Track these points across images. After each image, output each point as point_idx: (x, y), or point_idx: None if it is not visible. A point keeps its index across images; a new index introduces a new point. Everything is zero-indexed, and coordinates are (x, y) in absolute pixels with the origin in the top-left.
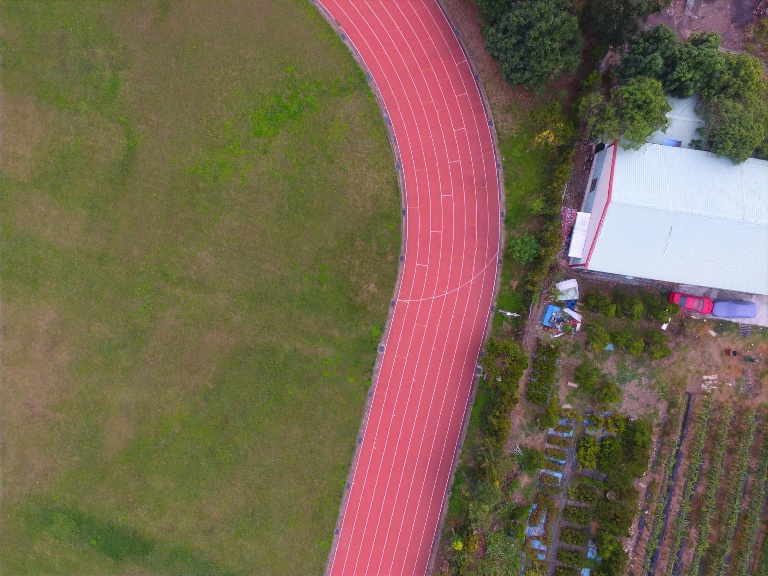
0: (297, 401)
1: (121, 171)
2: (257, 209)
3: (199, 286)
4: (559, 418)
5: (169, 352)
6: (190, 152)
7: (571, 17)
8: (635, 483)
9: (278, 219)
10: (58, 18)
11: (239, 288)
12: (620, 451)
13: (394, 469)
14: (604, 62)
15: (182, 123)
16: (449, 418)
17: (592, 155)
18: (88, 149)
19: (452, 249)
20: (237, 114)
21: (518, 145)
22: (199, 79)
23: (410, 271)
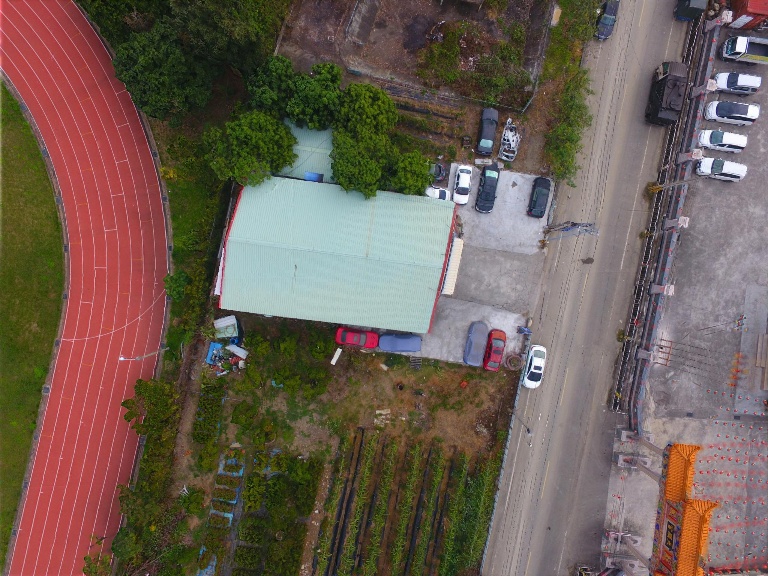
0: None
1: None
2: None
3: None
4: (226, 458)
5: None
6: None
7: None
8: (308, 521)
9: None
10: None
11: None
12: (286, 490)
13: (62, 513)
14: None
15: None
16: (120, 459)
17: None
18: None
19: (118, 285)
20: None
21: None
22: None
23: (74, 309)
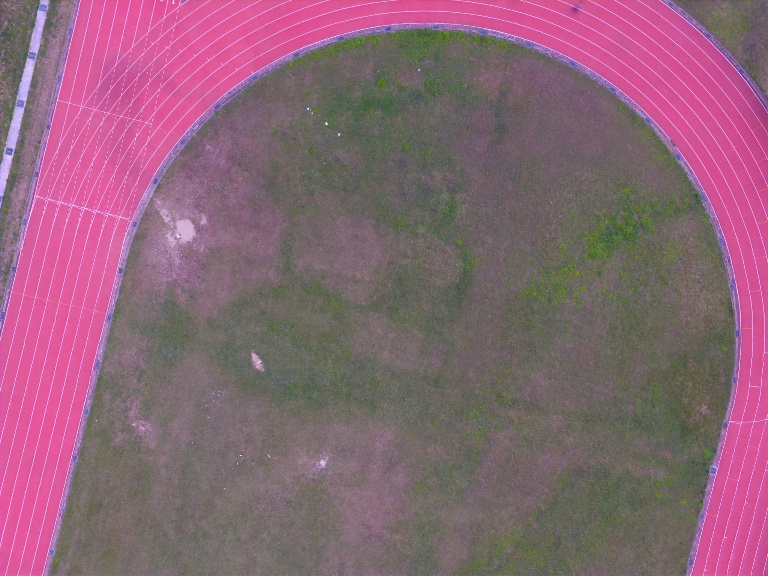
0: (629, 523)
1: (457, 294)
2: (591, 331)
3: (533, 408)
4: None
5: (503, 474)
6: (525, 274)
7: None
8: None
9: (612, 341)
10: (397, 142)
11: (572, 410)
12: None
13: None
14: None
15: (518, 245)
16: None
17: None
18: (425, 272)
19: None
20: (572, 236)
21: None
22: (535, 202)
23: (743, 393)
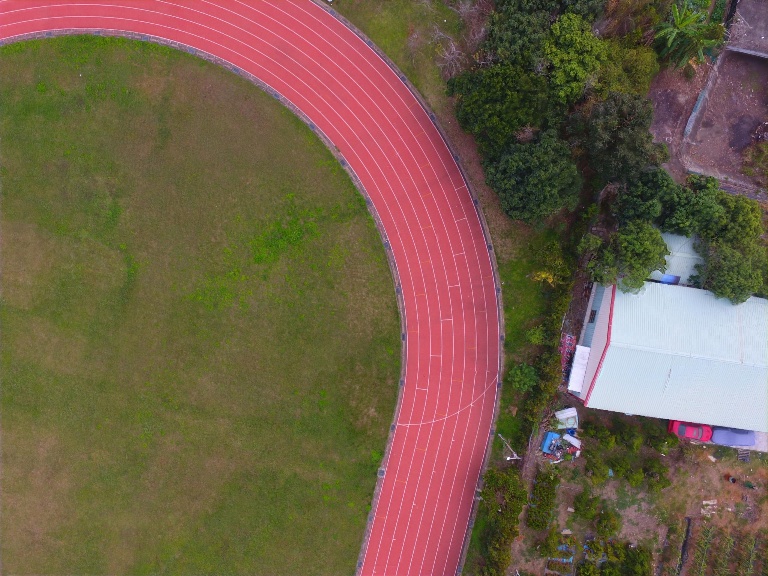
0: (297, 526)
1: (122, 298)
2: (257, 335)
3: (199, 412)
4: (559, 544)
5: (169, 478)
6: (190, 279)
7: (570, 164)
8: None
9: (278, 345)
10: (59, 147)
11: (239, 414)
12: None
13: None
14: (603, 190)
15: (182, 250)
16: (449, 542)
17: (591, 282)
18: (89, 276)
19: (452, 373)
20: (237, 241)
21: (517, 269)
22: (199, 206)
23: (410, 395)
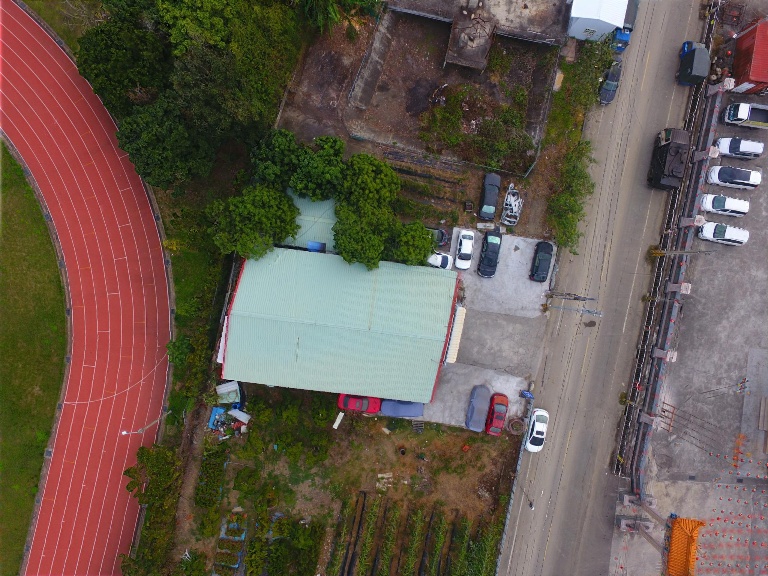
0: None
1: None
2: None
3: None
4: (228, 522)
5: None
6: None
7: (180, 125)
8: None
9: None
10: None
11: None
12: (288, 555)
13: None
14: None
15: None
16: (122, 522)
17: None
18: None
19: (120, 349)
20: None
21: (186, 240)
22: None
23: (76, 372)
